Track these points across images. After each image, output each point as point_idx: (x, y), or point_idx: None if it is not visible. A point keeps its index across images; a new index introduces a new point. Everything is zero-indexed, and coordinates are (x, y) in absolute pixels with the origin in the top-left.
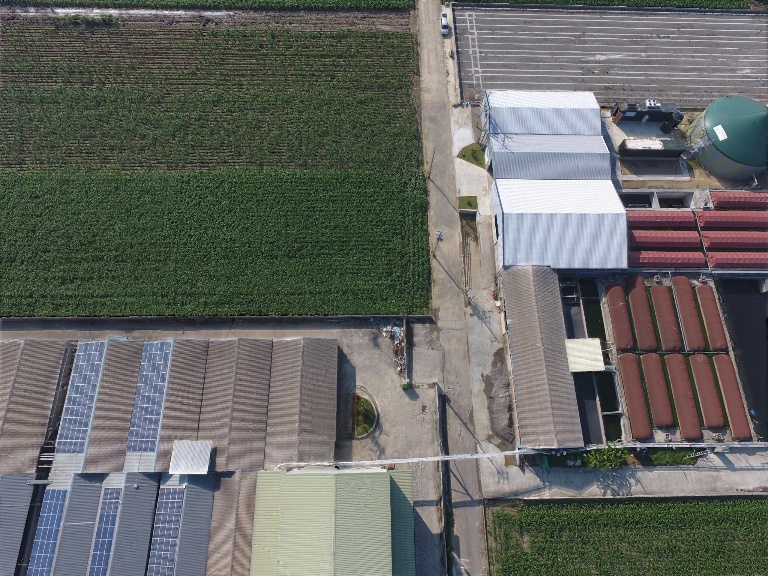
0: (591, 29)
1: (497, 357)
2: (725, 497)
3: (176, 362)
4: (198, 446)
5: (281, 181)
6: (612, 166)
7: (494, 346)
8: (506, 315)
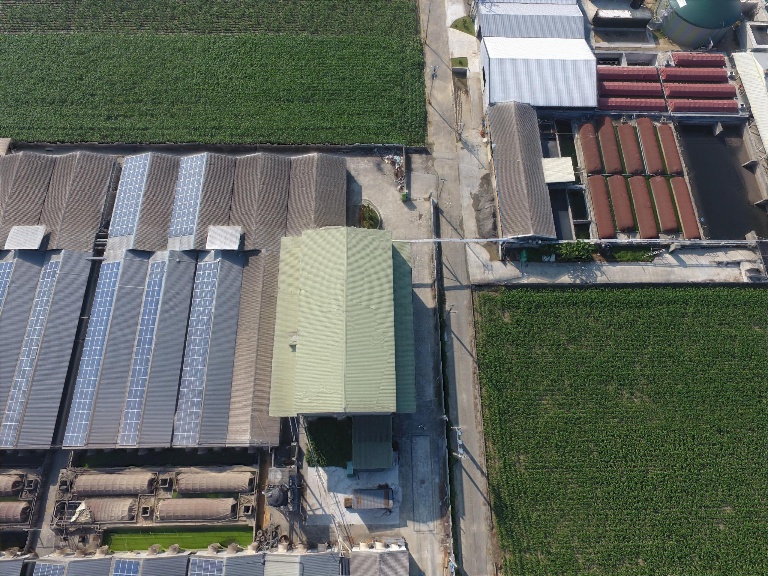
0: None
1: (484, 180)
2: (677, 285)
3: (209, 170)
4: (230, 230)
5: (296, 43)
6: (587, 35)
7: (481, 172)
8: (491, 141)
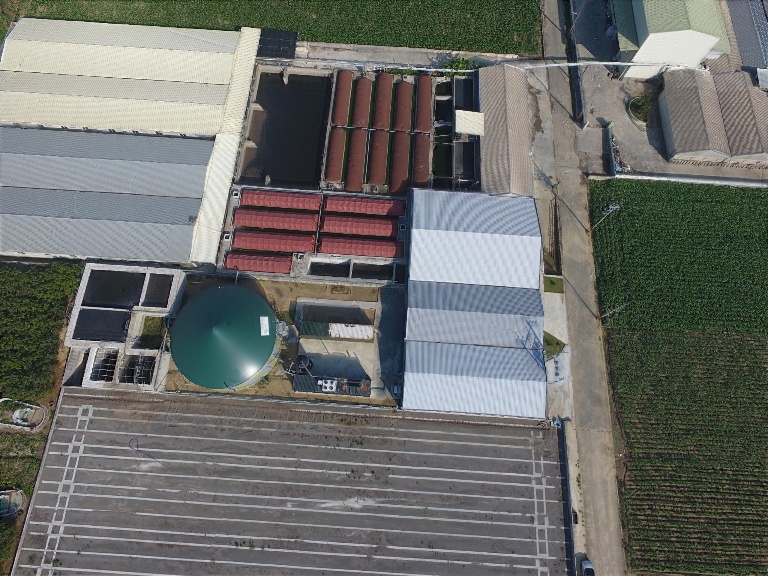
0: (356, 567)
1: None
2: None
3: None
4: None
5: (762, 319)
6: (385, 320)
7: (532, 152)
8: None
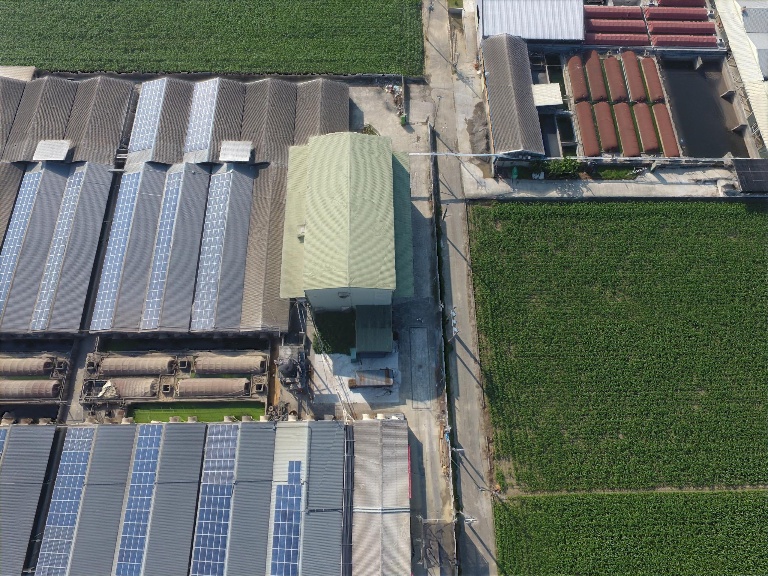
0: None
1: (478, 108)
2: (658, 199)
3: (221, 93)
4: (241, 144)
5: None
6: None
7: (475, 100)
8: (485, 69)
